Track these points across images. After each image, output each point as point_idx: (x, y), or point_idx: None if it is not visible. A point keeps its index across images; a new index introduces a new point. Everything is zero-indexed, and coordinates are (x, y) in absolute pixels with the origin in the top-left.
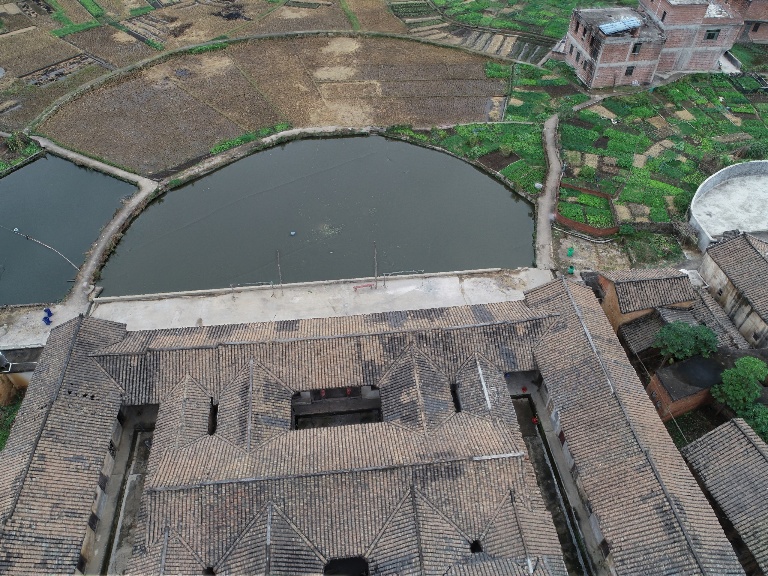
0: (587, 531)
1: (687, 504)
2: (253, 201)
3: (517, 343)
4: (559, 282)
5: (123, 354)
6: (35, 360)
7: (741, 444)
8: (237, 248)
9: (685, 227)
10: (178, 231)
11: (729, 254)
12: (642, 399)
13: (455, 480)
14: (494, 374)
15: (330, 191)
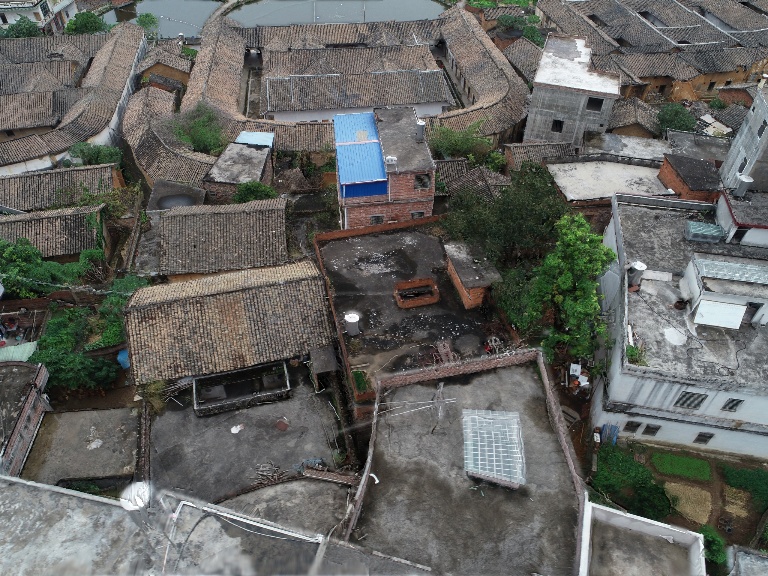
0: (459, 87)
1: (494, 53)
2: (294, 7)
3: (433, 28)
4: (455, 7)
5: (245, 28)
6: (198, 41)
7: (524, 43)
8: (288, 22)
9: (533, 7)
10: (252, 20)
11: (545, 3)
12: (486, 37)
13: (399, 52)
14: (421, 39)
15: (338, 4)
